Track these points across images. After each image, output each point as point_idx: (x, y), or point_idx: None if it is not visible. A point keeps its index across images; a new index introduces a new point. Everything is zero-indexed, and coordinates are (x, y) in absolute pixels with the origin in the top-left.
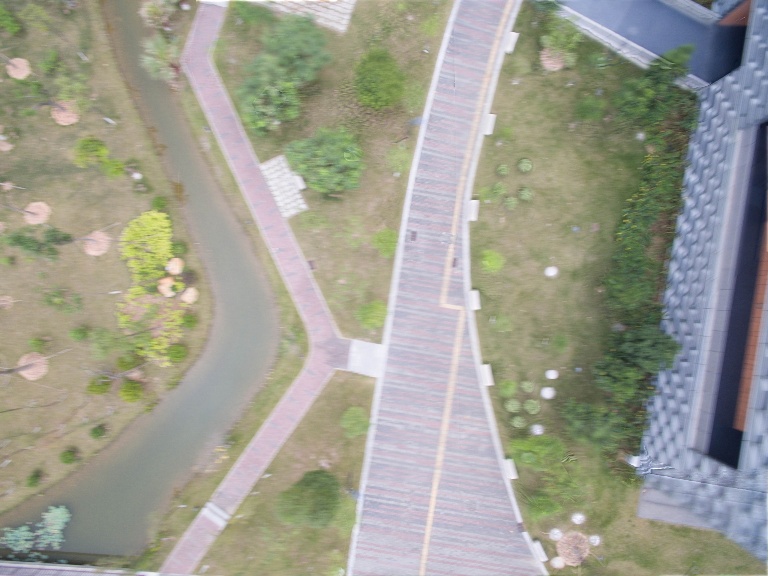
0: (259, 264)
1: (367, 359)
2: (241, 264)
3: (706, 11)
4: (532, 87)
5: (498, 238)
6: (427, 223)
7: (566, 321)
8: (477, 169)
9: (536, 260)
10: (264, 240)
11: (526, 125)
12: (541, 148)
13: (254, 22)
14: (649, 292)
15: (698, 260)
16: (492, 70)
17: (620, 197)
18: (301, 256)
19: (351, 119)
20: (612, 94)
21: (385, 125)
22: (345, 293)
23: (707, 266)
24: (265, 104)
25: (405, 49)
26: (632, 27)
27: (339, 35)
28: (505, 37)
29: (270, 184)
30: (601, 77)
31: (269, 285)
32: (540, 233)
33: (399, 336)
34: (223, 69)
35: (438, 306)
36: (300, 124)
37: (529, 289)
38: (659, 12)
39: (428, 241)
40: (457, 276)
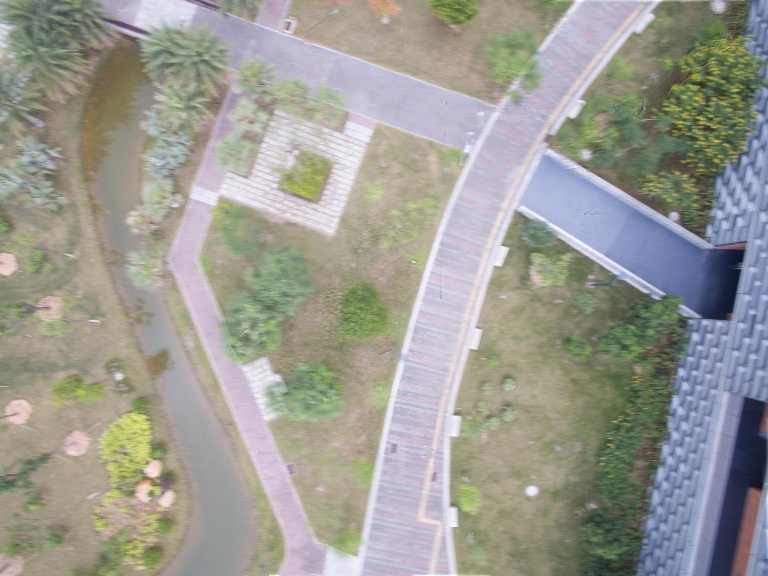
0: (238, 465)
1: (342, 569)
2: (220, 465)
3: (700, 240)
4: (520, 301)
5: (479, 453)
6: (408, 436)
7: (545, 543)
8: (461, 384)
9: (517, 479)
10: (244, 441)
11: (512, 340)
12: (527, 364)
13: (242, 222)
14: (630, 521)
15: (679, 511)
16: (480, 282)
17: (605, 417)
18: (280, 460)
19: (336, 326)
20: (601, 314)
21: (369, 335)
22: (323, 501)
23: (687, 525)
24: (244, 346)
25: (393, 258)
26: (624, 249)
27: (327, 238)
28: (495, 250)
29: (252, 386)
30: (591, 296)
31: (247, 487)
32: (522, 451)
33: (375, 549)
34: (209, 268)
35: (416, 520)
36: (284, 327)
37: (509, 508)
38: (652, 235)
39: (408, 454)
40: (436, 490)
